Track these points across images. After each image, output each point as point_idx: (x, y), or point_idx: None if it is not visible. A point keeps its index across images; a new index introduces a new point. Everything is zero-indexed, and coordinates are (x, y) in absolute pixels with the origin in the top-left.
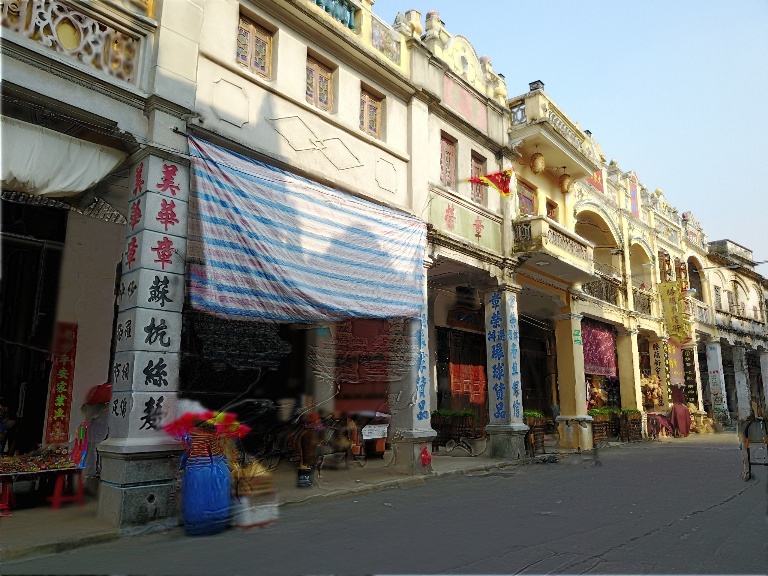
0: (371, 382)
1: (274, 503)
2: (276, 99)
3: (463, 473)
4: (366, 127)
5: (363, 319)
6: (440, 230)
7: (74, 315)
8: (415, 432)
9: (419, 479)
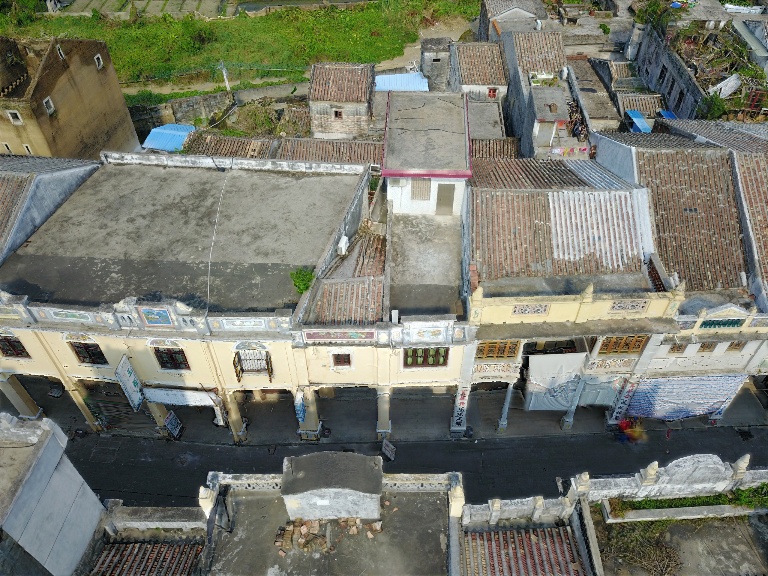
0: (688, 416)
1: (644, 430)
2: (680, 358)
3: (732, 426)
4: (732, 347)
5: (693, 404)
6: (765, 368)
7: (604, 399)
8: (711, 418)
9: (705, 428)
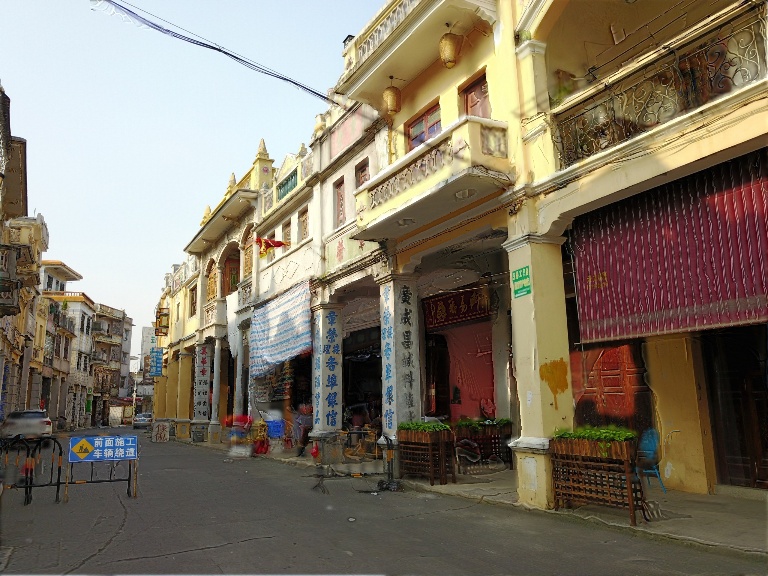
0: None
1: (265, 456)
2: (274, 266)
3: None
4: None
5: None
6: (333, 269)
7: None
8: None
9: None
